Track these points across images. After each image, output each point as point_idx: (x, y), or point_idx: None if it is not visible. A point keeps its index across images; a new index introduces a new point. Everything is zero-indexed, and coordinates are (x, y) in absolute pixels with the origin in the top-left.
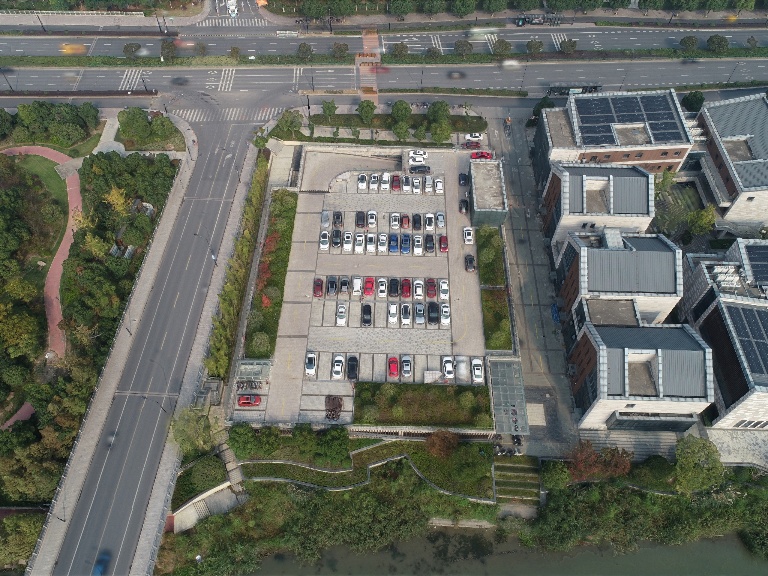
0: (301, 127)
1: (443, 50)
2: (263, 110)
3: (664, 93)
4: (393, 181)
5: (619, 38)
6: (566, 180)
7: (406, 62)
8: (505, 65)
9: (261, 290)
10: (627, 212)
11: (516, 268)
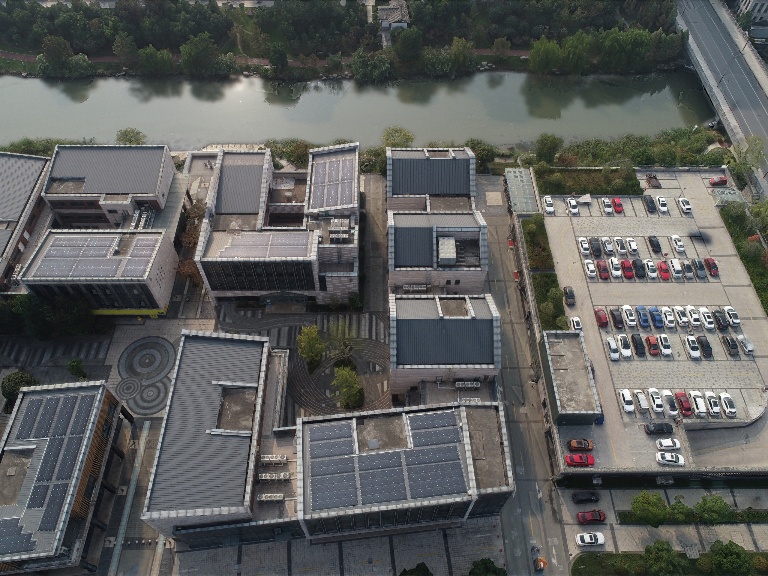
0: None
1: None
2: None
3: (314, 515)
4: None
5: None
6: (495, 312)
7: None
8: None
9: (765, 260)
10: (418, 300)
11: (513, 319)
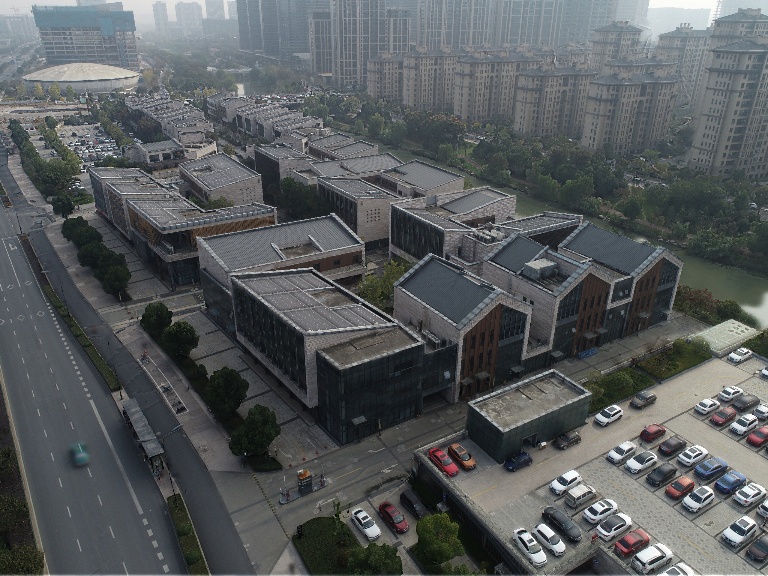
0: None
1: None
2: None
3: None
4: (640, 542)
5: None
6: None
7: None
8: None
9: None
10: None
11: None
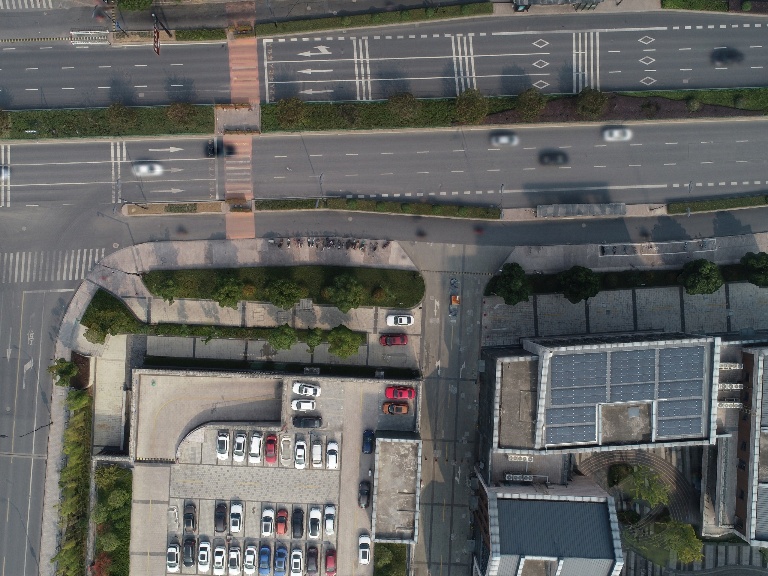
0: (132, 300)
1: (371, 85)
2: (69, 256)
3: (703, 341)
4: (266, 451)
5: (694, 48)
6: (495, 565)
7: (303, 128)
8: (475, 130)
9: None
10: None
11: (427, 570)
